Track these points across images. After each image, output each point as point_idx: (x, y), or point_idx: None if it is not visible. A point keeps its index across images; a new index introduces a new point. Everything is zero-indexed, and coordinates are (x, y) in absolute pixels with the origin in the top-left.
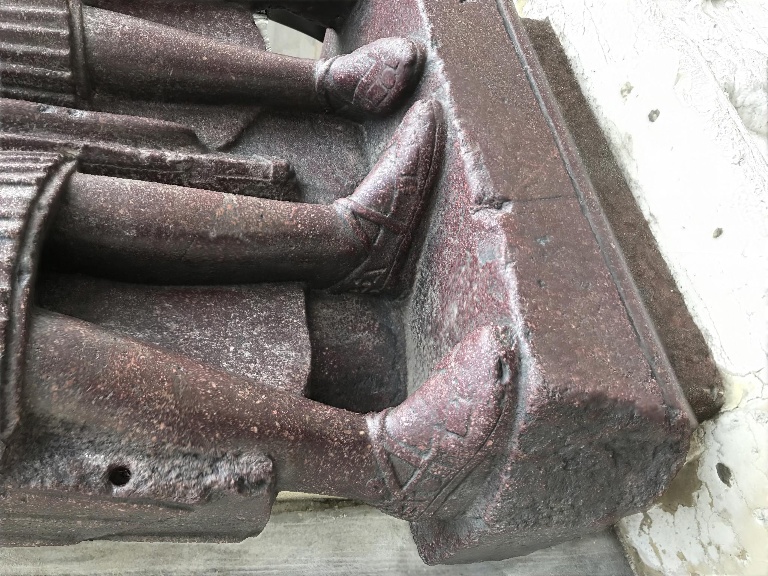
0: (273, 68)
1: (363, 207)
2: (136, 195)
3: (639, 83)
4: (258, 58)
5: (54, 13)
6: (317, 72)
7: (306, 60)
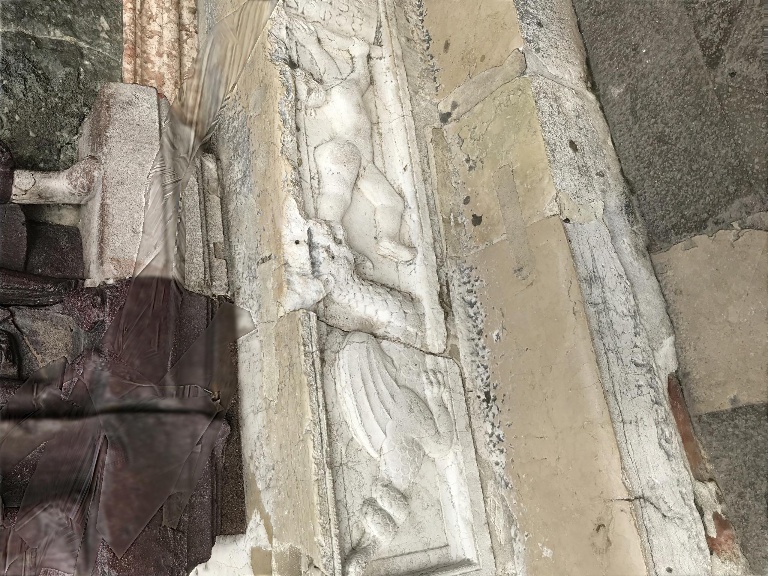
0: None
1: None
2: None
3: (206, 573)
4: None
5: None
6: None
7: None
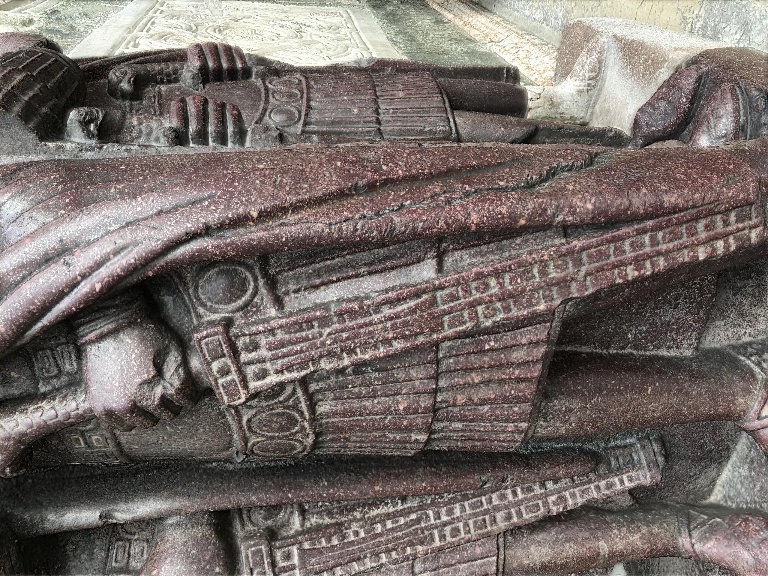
0: (699, 420)
1: (701, 559)
2: (542, 571)
3: None
4: (689, 416)
5: (513, 440)
6: (743, 422)
7: (740, 405)
